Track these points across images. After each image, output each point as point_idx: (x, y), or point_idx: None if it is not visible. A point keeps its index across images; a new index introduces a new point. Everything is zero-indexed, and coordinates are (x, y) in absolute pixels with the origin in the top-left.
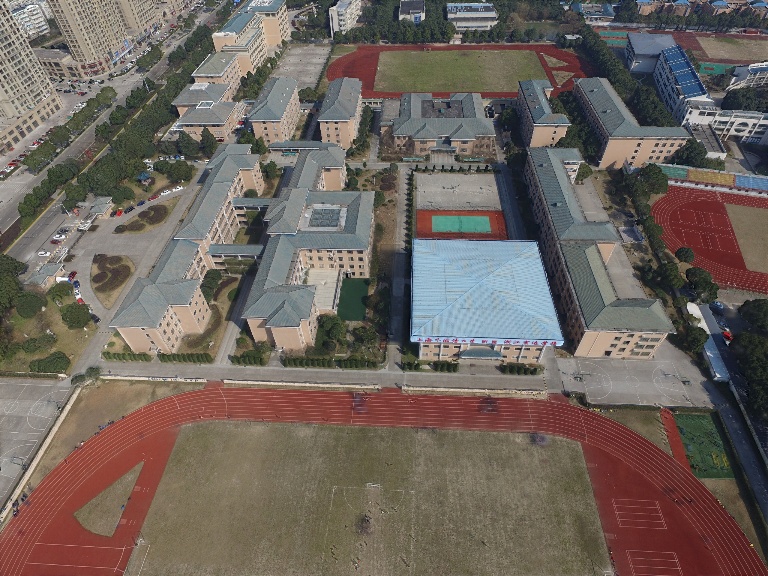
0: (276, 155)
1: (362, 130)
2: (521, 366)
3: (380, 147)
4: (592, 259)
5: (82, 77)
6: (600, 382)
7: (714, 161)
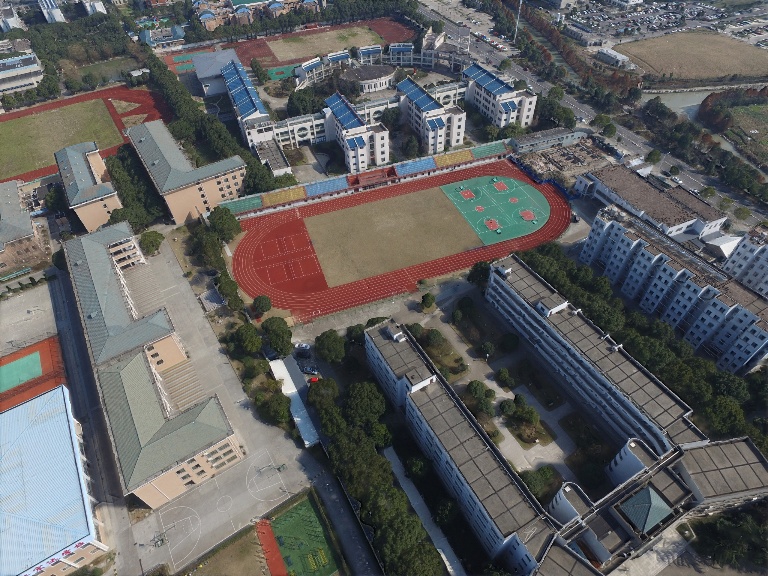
0: None
1: None
2: (81, 573)
3: None
4: (131, 380)
5: None
6: (187, 530)
7: (283, 178)
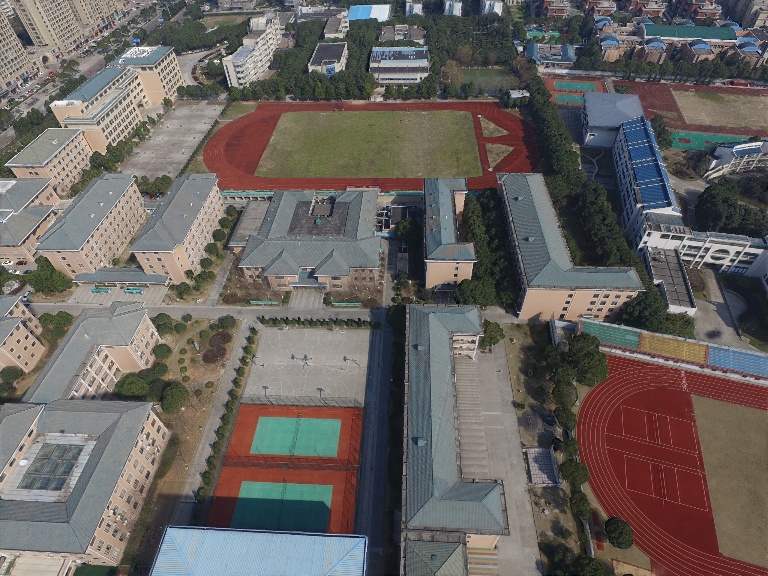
0: (85, 290)
1: (210, 249)
2: None
3: (229, 276)
4: None
5: None
6: None
7: (678, 319)
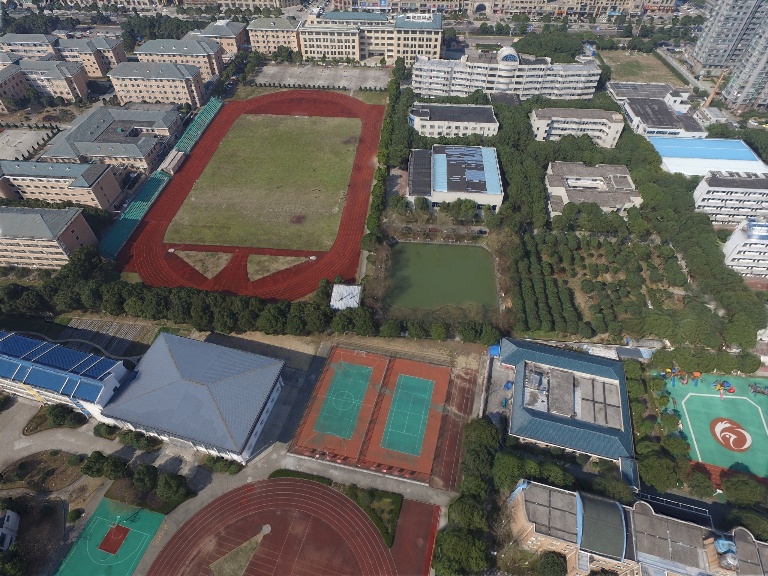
0: None
1: None
2: None
3: None
4: None
5: (333, 6)
6: None
7: None
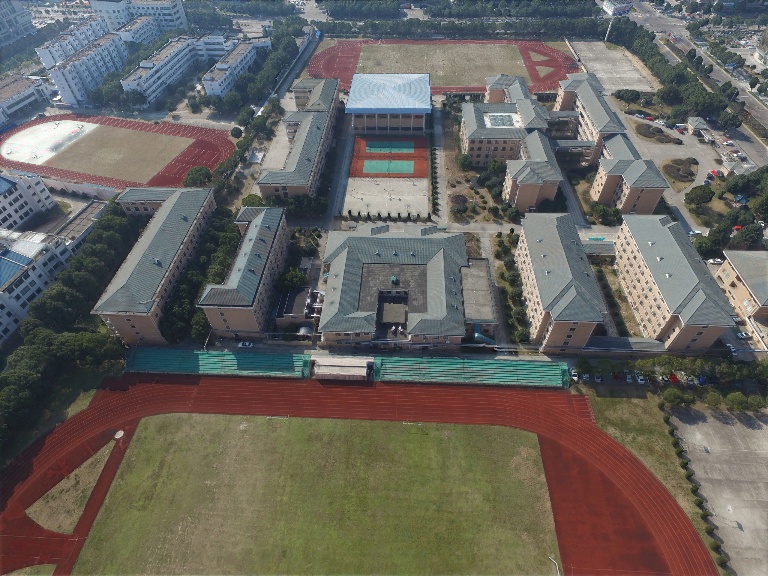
0: None
1: None
2: None
3: None
4: None
5: None
6: None
7: None
